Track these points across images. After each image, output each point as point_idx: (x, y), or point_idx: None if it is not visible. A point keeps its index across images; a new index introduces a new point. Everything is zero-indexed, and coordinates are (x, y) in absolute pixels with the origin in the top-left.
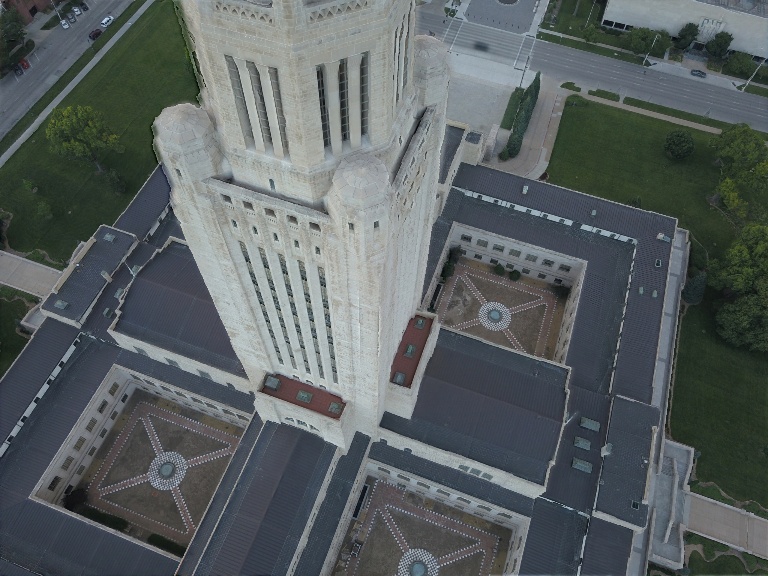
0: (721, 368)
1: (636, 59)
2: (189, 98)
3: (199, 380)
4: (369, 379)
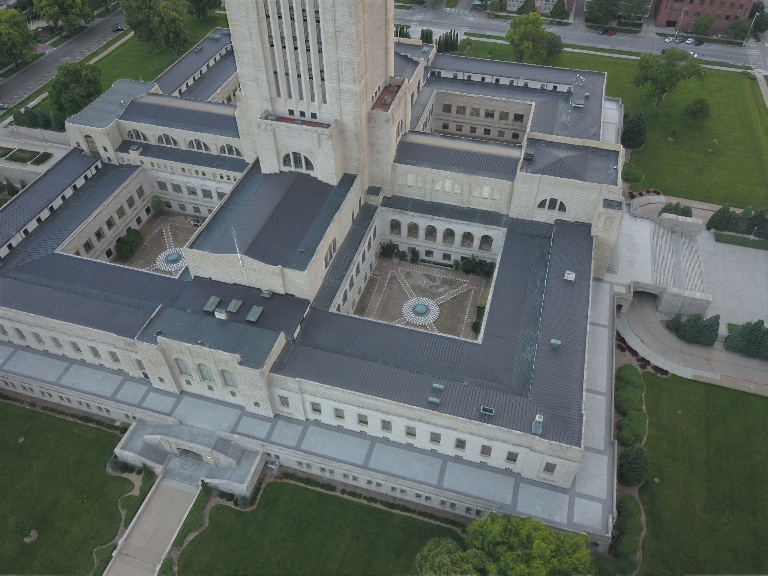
0: (373, 575)
1: None
2: (622, 100)
3: None
4: None
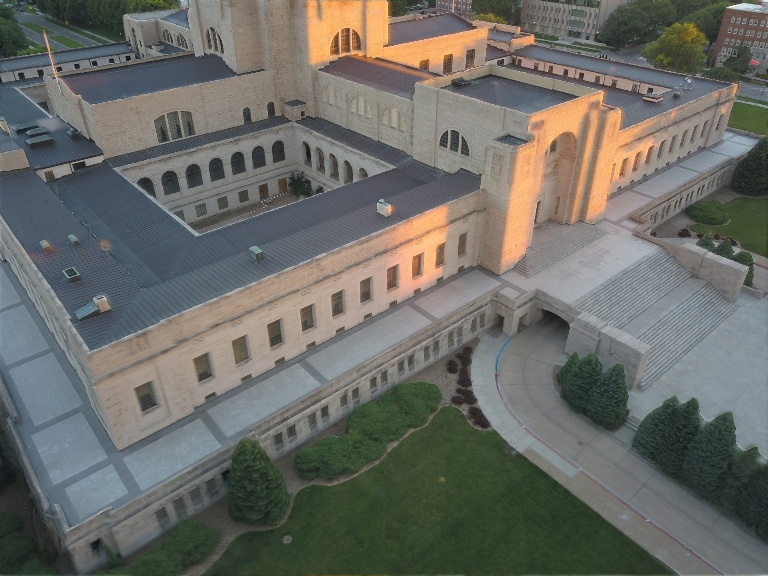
0: None
1: None
2: None
3: None
4: None
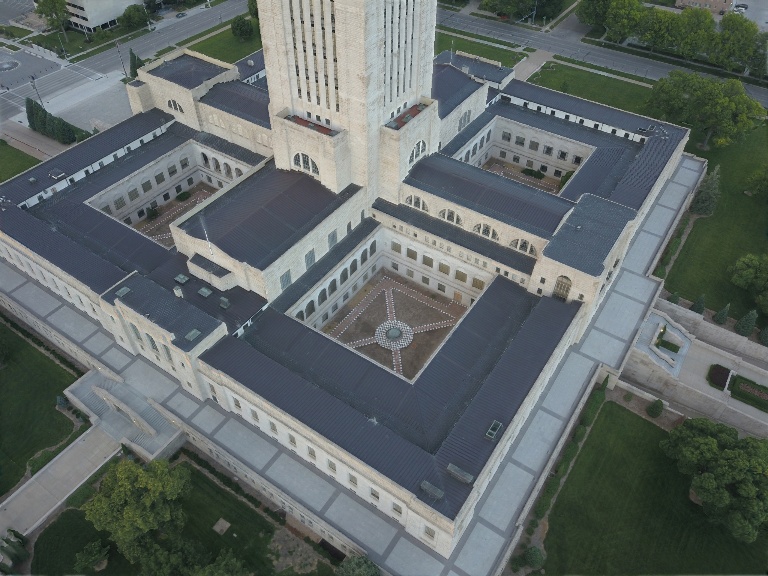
0: None
1: (143, 32)
2: None
3: (332, 253)
4: (432, 31)
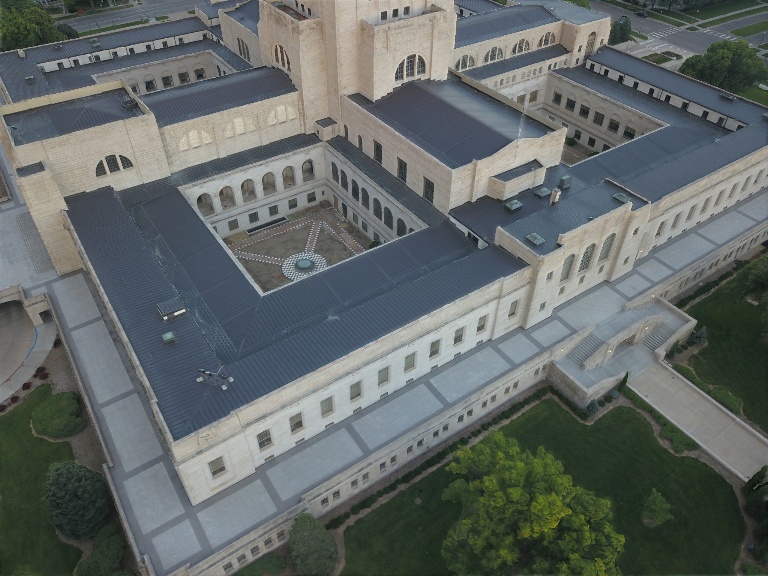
0: None
1: None
2: None
3: None
4: None
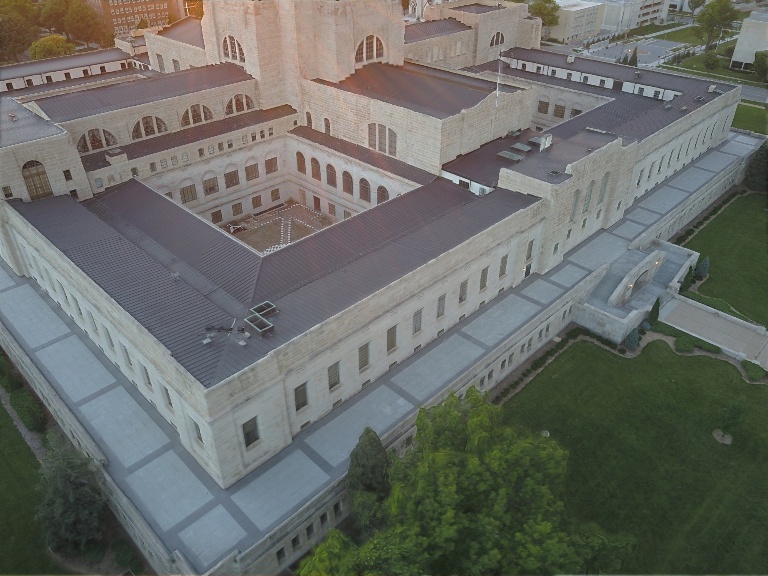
0: None
1: (762, 85)
2: None
3: None
4: None
